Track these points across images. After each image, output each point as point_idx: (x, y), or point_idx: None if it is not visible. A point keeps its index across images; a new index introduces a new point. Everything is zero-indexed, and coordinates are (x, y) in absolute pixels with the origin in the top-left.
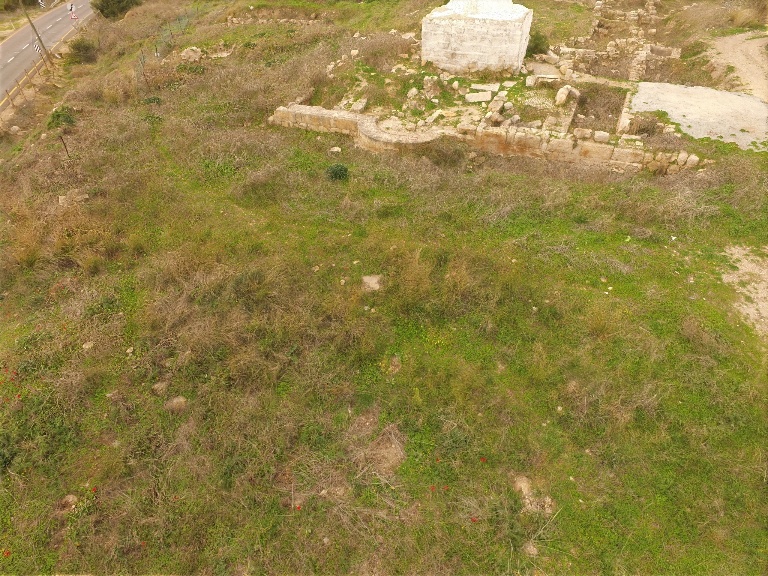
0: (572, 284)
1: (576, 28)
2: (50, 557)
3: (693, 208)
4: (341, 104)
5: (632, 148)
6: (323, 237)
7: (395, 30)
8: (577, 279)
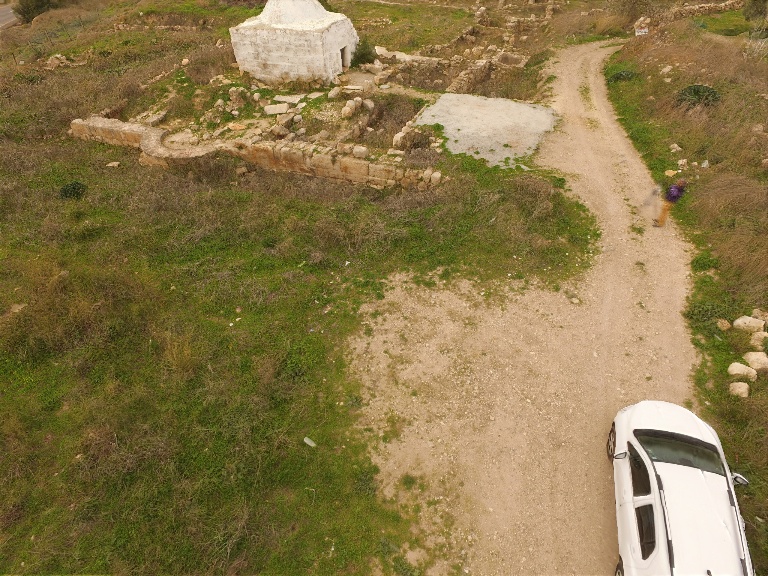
0: (207, 314)
1: (440, 35)
2: None
3: (378, 231)
4: (139, 116)
5: (387, 164)
6: None
7: None
8: (212, 309)
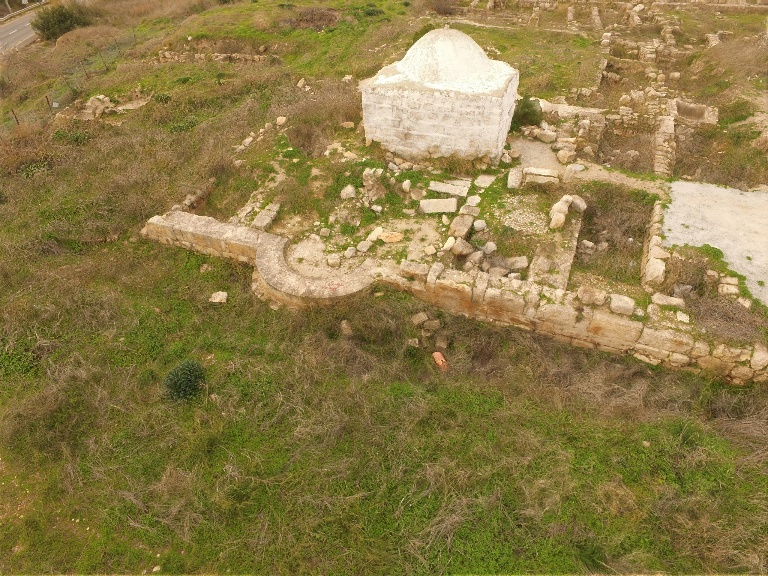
0: None
1: (579, 74)
2: None
3: None
4: (241, 213)
5: (672, 329)
6: (107, 572)
7: (350, 76)
8: None
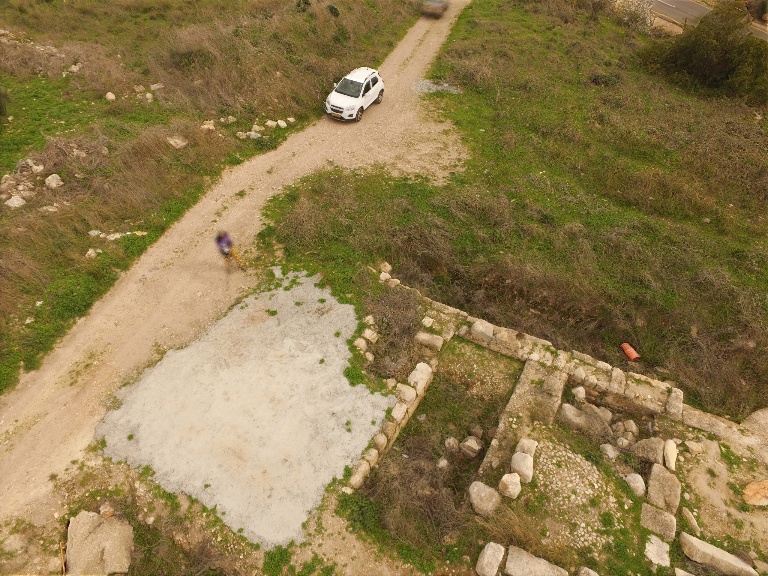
0: None
1: None
2: (767, 130)
3: None
4: None
5: (444, 312)
6: None
7: None
8: None
